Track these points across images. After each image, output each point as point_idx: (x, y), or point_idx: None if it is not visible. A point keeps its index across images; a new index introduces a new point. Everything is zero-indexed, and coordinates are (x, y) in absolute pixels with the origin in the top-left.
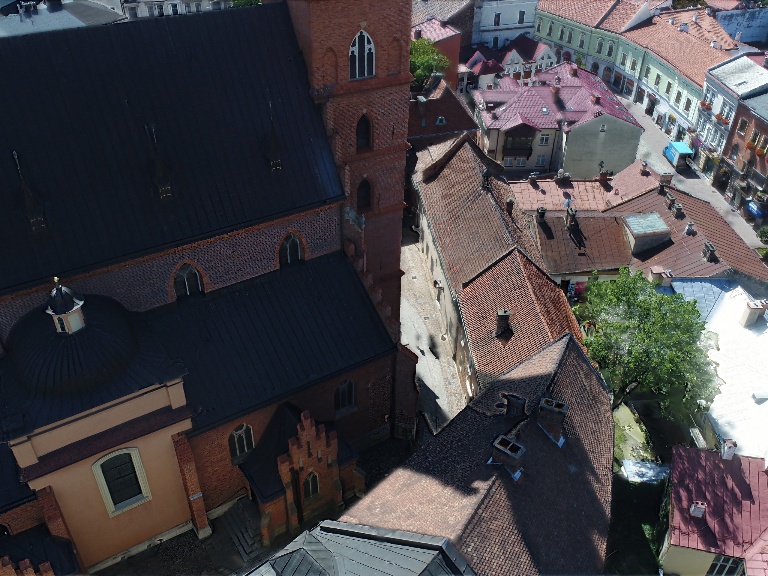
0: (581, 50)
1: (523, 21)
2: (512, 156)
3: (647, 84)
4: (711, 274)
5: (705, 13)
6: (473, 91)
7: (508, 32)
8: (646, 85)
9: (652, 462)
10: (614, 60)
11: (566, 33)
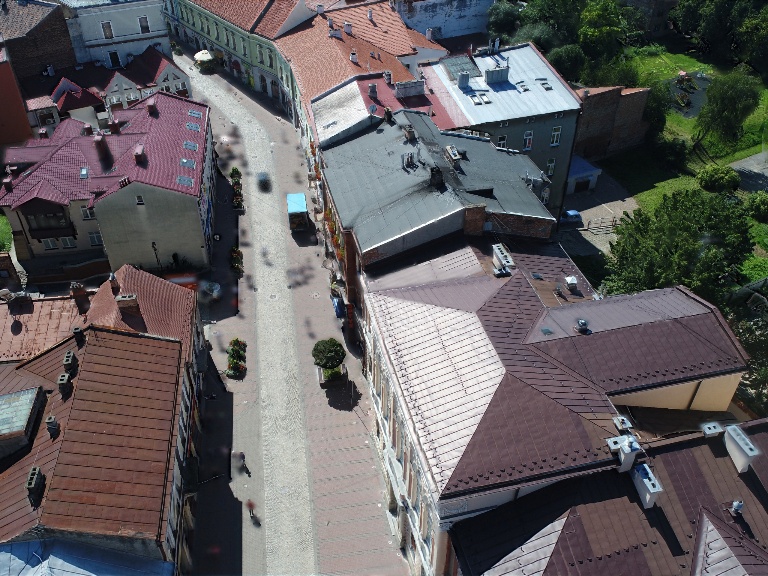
0: (246, 59)
1: (148, 29)
2: (45, 238)
3: (297, 107)
4: (15, 534)
5: (389, 6)
6: (28, 140)
7: (129, 45)
8: (297, 108)
9: None
10: (276, 73)
11: (230, 37)
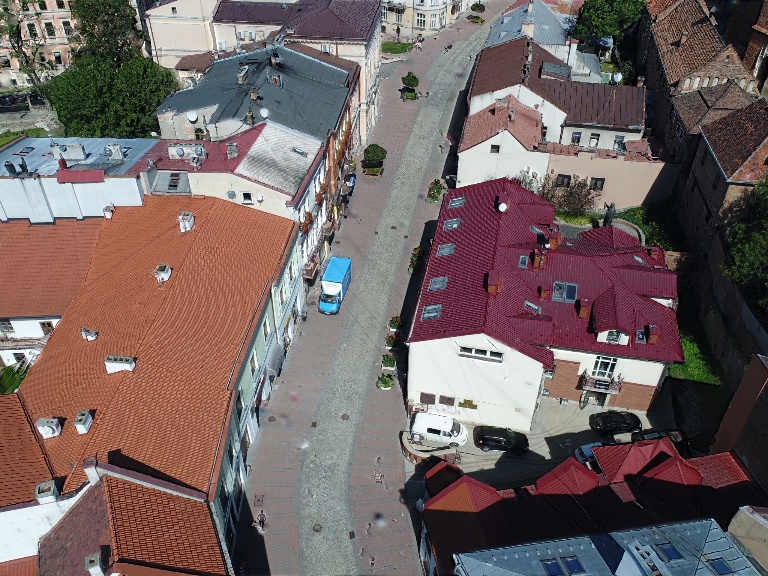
0: None
1: None
2: None
3: None
4: (536, 44)
5: None
6: (683, 358)
7: None
8: None
9: None
10: None
11: None
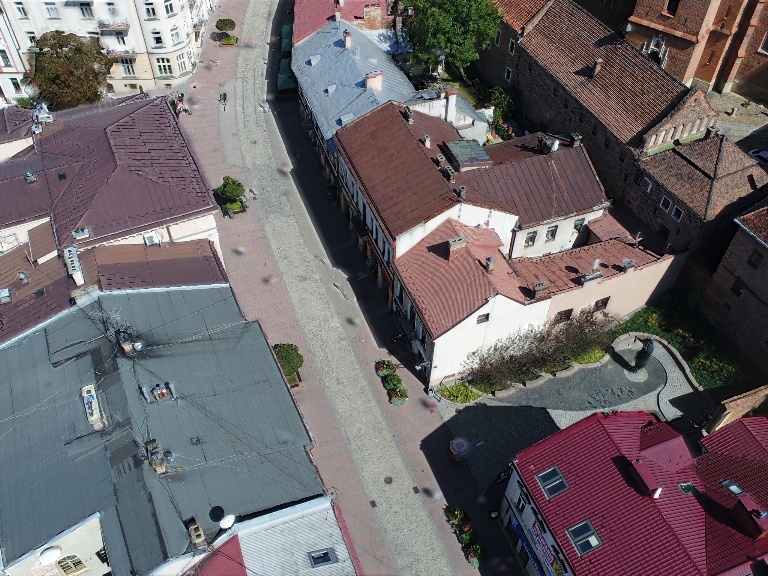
0: None
1: None
2: None
3: None
4: None
5: None
6: None
7: None
8: None
9: (425, 86)
10: None
11: None
